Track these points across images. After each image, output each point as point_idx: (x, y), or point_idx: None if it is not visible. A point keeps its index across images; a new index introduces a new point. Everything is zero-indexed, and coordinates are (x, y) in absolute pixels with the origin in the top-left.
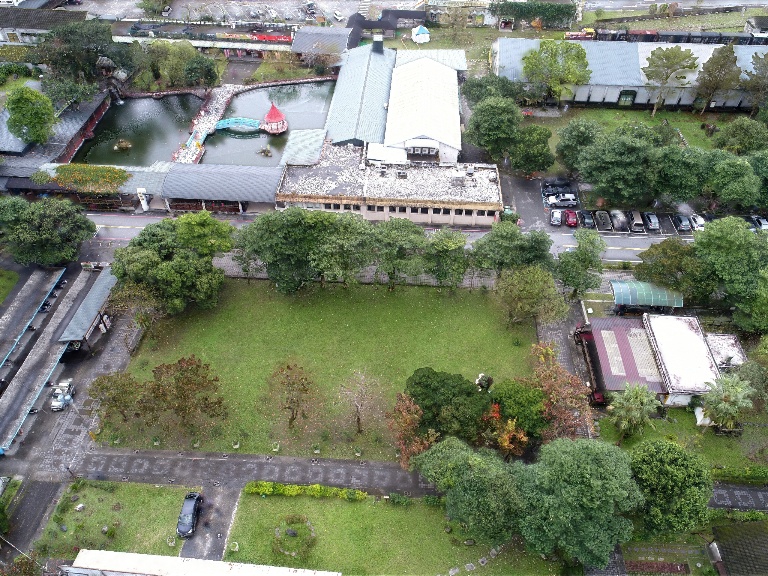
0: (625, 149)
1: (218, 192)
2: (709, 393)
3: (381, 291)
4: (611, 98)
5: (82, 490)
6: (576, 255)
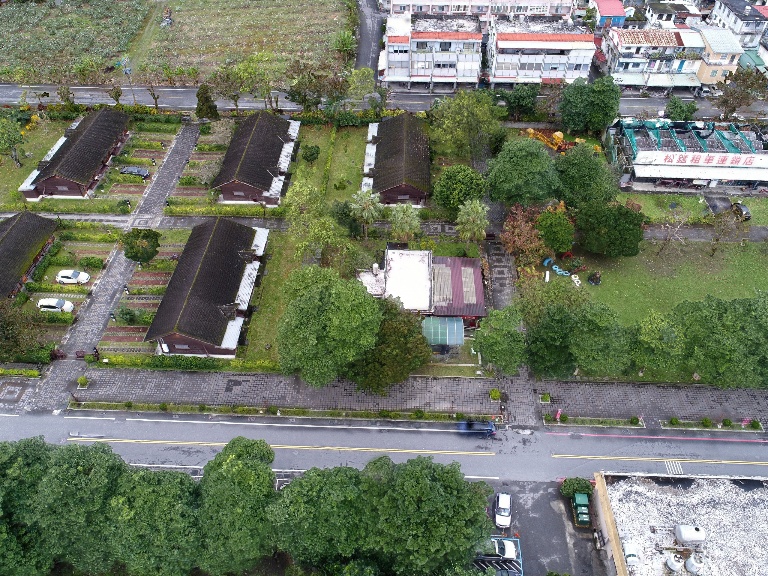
0: None
1: None
2: (415, 226)
3: None
4: None
5: None
6: None
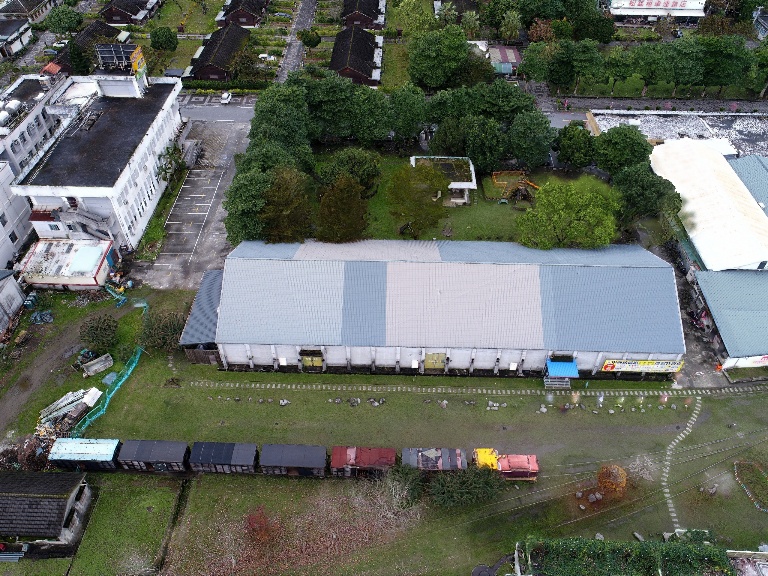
0: None
1: None
2: (477, 26)
3: (649, 94)
4: None
5: None
6: (537, 63)
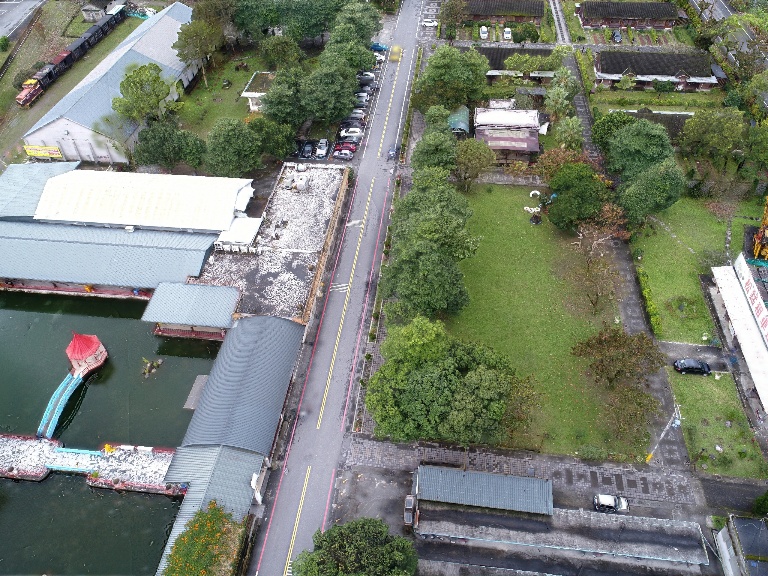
0: (331, 77)
1: (278, 383)
2: (553, 108)
3: None
4: (174, 97)
5: None
6: None
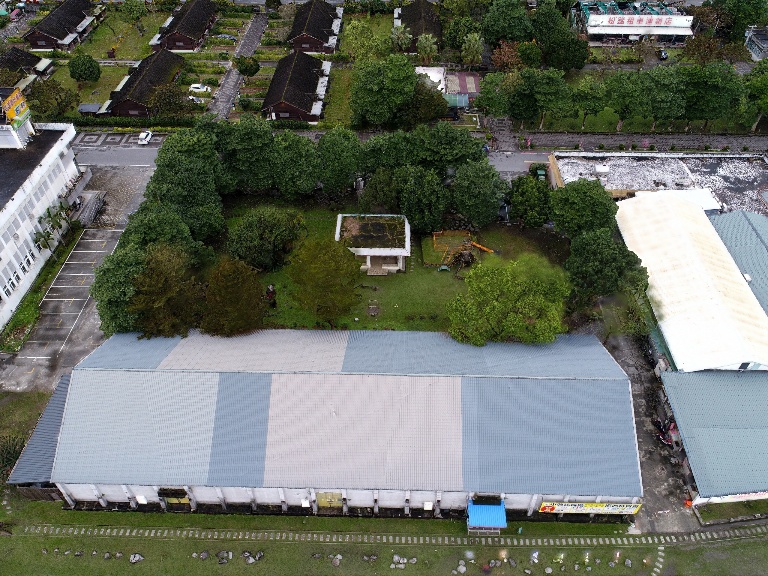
0: None
1: None
2: (434, 50)
3: (625, 129)
4: None
5: (717, 60)
6: (496, 96)
